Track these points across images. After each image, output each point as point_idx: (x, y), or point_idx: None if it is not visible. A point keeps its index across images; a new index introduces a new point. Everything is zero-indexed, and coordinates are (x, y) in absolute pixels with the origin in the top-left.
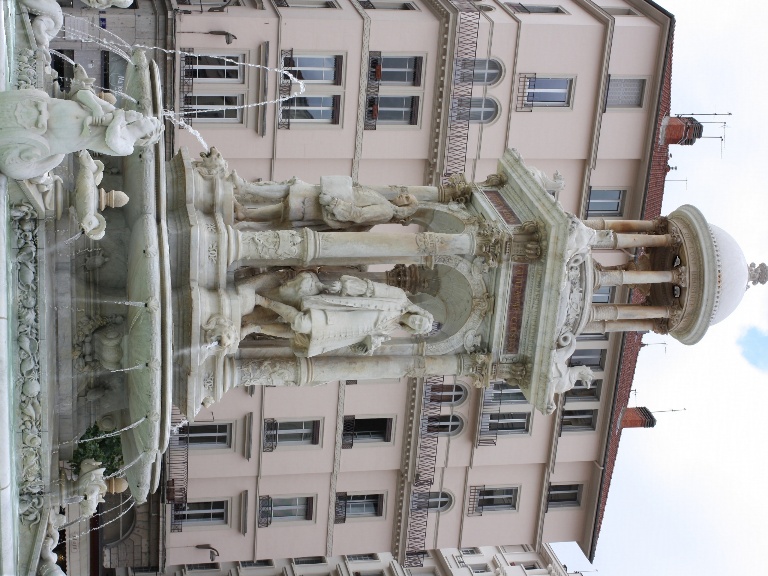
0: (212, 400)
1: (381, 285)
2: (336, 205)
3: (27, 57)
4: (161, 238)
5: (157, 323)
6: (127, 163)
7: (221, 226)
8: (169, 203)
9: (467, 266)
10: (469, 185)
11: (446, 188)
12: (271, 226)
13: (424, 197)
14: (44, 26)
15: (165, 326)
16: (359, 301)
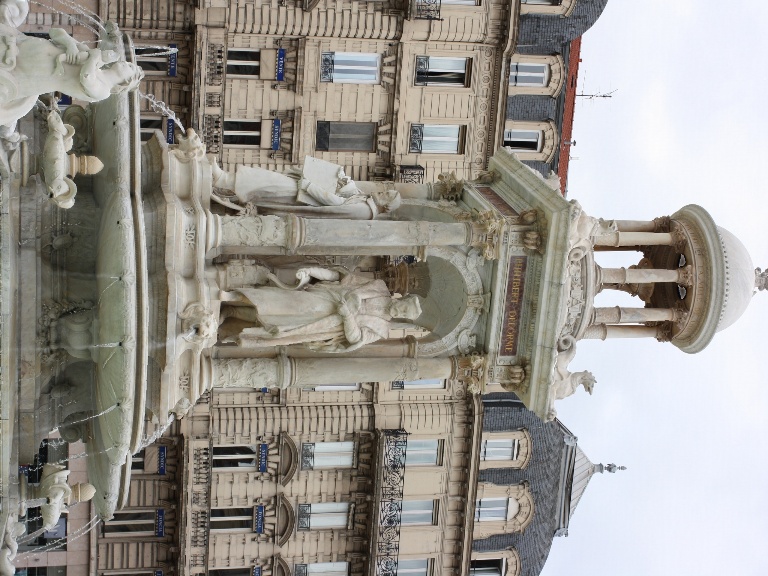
0: None
1: None
2: None
3: None
4: None
5: None
6: None
7: None
8: None
9: None
10: None
11: None
12: None
13: None
14: None
15: None
16: None
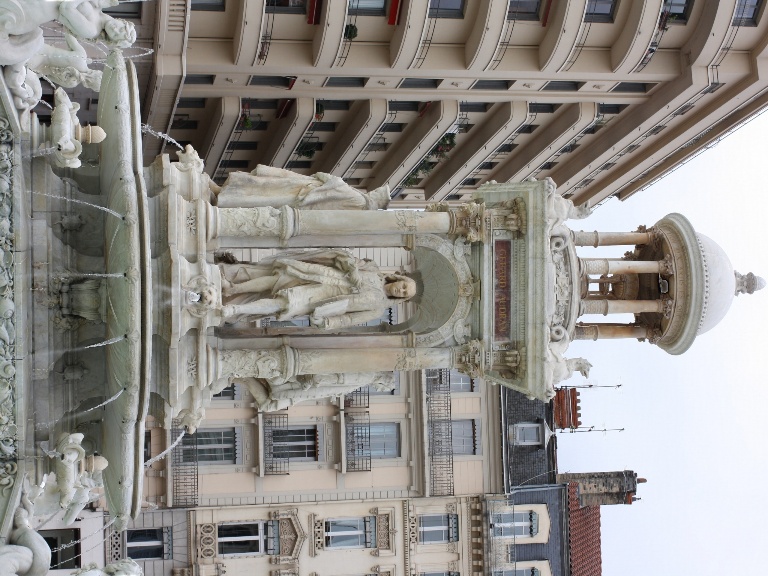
0: None
1: (352, 377)
2: (325, 329)
3: (3, 248)
4: (137, 451)
5: (126, 522)
6: (110, 380)
7: (201, 373)
8: None
9: None
10: (482, 239)
11: (458, 227)
12: (258, 298)
13: (432, 232)
14: (20, 71)
15: (134, 513)
16: (326, 392)
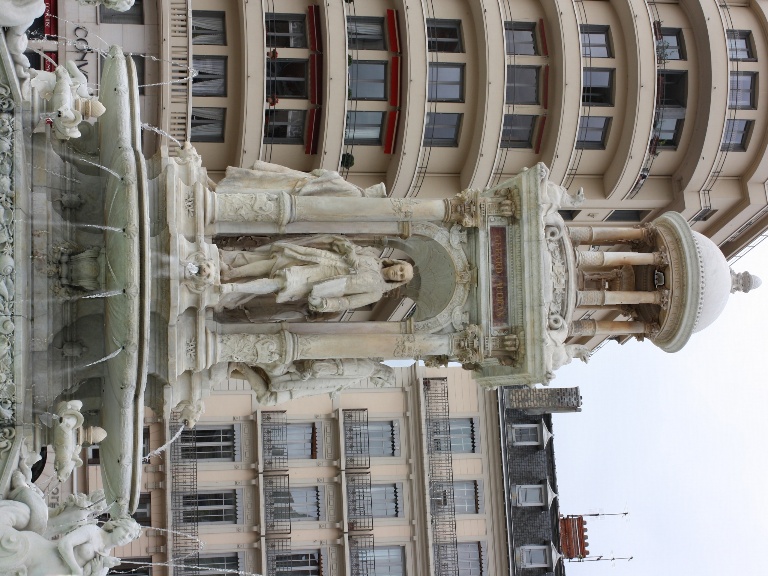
0: None
1: (351, 367)
2: (323, 310)
3: (3, 205)
4: (136, 429)
5: (125, 509)
6: None
7: (200, 353)
8: (151, 311)
9: None
10: (477, 225)
11: (454, 213)
12: None
13: (428, 219)
14: None
15: (133, 501)
16: (326, 384)
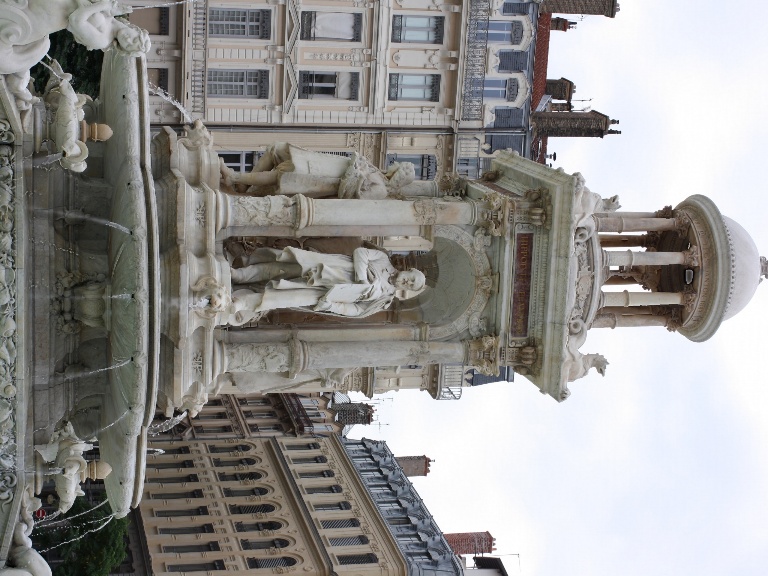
0: (219, 291)
1: None
2: None
3: None
4: None
5: None
6: None
7: None
8: None
9: (440, 200)
10: None
11: None
12: None
13: None
14: None
15: None
16: None
